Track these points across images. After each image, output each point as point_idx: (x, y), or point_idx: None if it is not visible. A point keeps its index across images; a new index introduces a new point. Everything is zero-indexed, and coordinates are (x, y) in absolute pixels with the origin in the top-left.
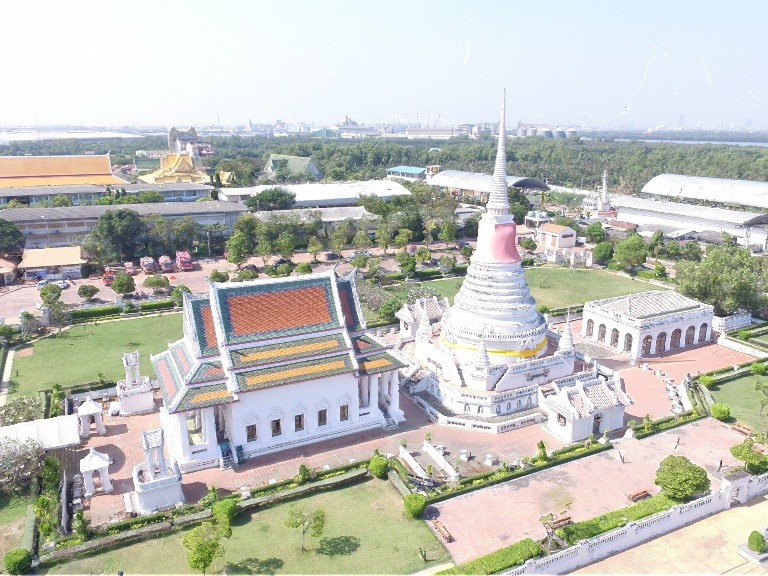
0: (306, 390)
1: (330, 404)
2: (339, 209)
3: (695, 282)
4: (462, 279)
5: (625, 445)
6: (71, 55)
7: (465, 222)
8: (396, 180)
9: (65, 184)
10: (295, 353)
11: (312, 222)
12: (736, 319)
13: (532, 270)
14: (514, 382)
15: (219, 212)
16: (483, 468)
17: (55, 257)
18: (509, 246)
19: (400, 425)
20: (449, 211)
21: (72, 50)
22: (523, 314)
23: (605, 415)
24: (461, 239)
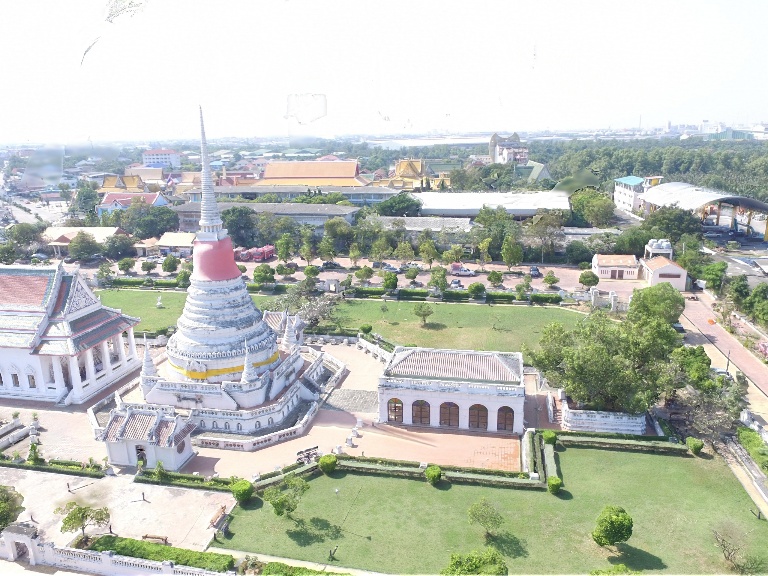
0: (1, 354)
1: (21, 371)
2: (442, 219)
3: (542, 351)
4: (440, 305)
5: (112, 480)
6: (323, 79)
7: (567, 245)
8: (587, 192)
9: (301, 184)
10: (0, 324)
11: (395, 230)
12: (602, 418)
13: (543, 309)
14: (165, 398)
15: (322, 214)
16: (23, 453)
17: (178, 240)
18: (205, 264)
19: (70, 406)
20: (541, 230)
21: (325, 74)
22: (206, 335)
23: (149, 449)
24: (558, 264)
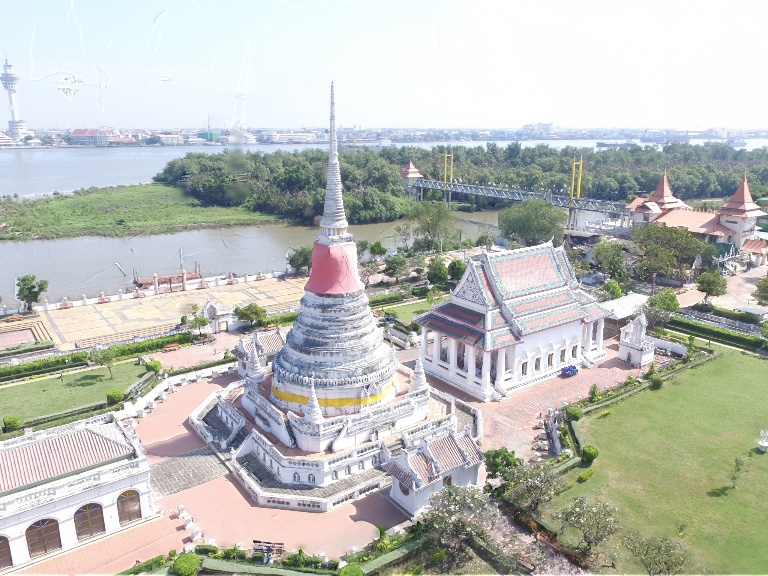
0: None
1: None
2: None
3: None
4: None
5: None
6: None
7: None
8: None
9: None
10: None
11: None
12: None
13: None
14: None
15: None
16: None
17: None
18: None
19: None
20: None
21: None
22: None
23: None
24: None
